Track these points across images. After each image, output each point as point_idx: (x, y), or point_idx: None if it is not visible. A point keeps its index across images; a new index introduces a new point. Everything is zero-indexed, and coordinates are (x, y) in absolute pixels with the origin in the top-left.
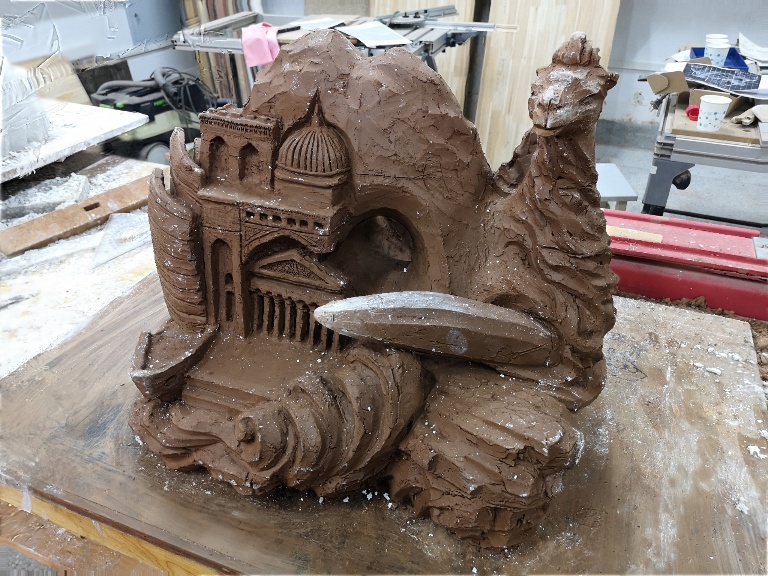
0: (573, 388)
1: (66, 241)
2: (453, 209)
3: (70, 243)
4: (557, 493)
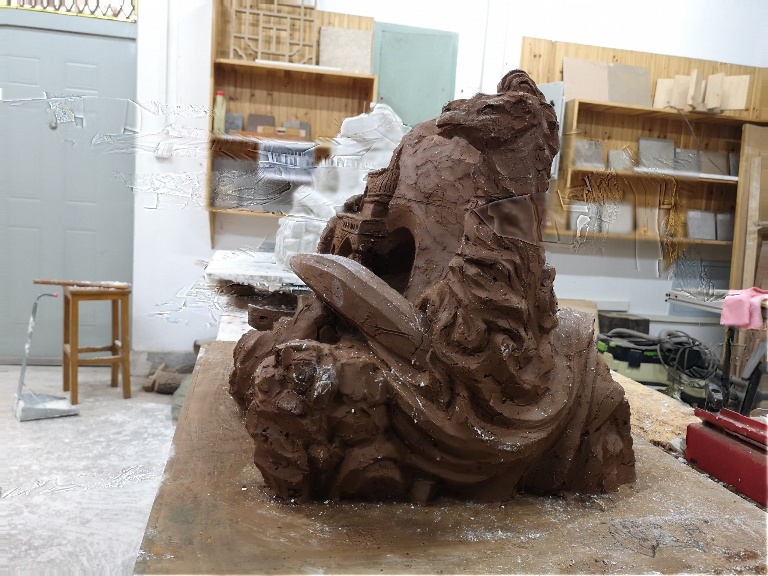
0: (428, 402)
1: None
2: (439, 232)
3: None
4: (284, 408)
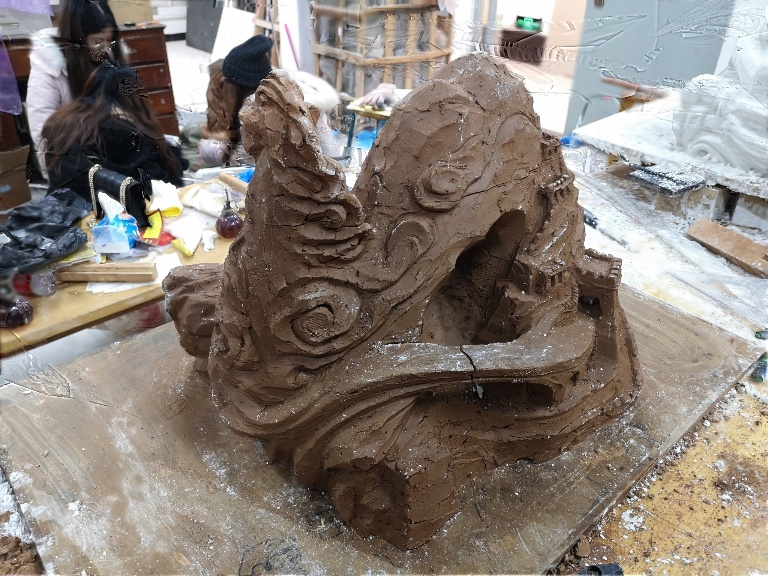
0: None
1: (722, 261)
2: None
3: (711, 259)
4: None
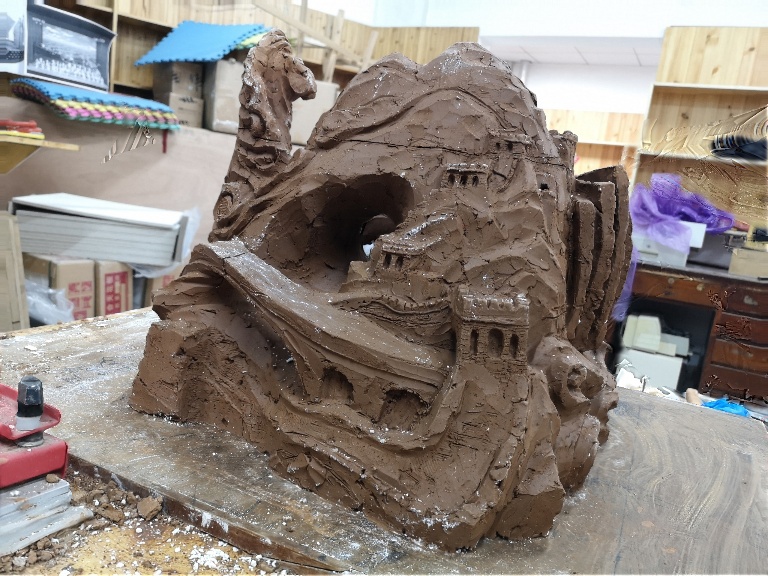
0: None
1: None
2: None
3: None
4: None
